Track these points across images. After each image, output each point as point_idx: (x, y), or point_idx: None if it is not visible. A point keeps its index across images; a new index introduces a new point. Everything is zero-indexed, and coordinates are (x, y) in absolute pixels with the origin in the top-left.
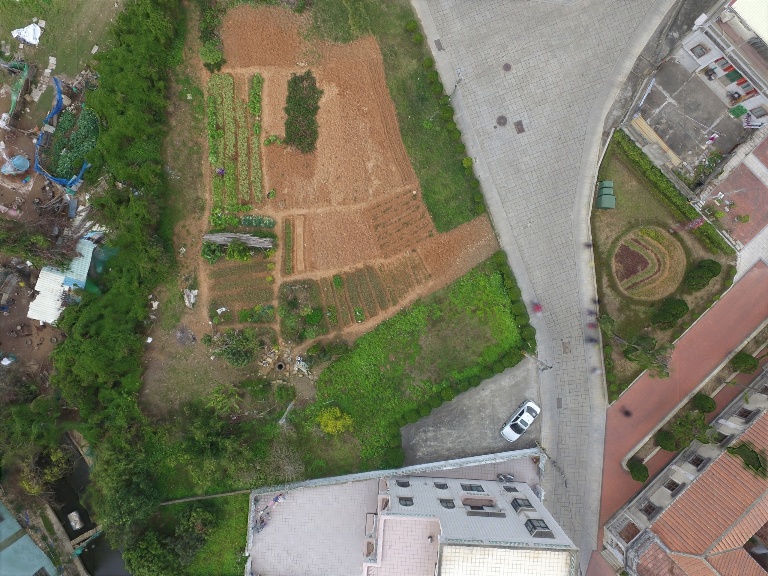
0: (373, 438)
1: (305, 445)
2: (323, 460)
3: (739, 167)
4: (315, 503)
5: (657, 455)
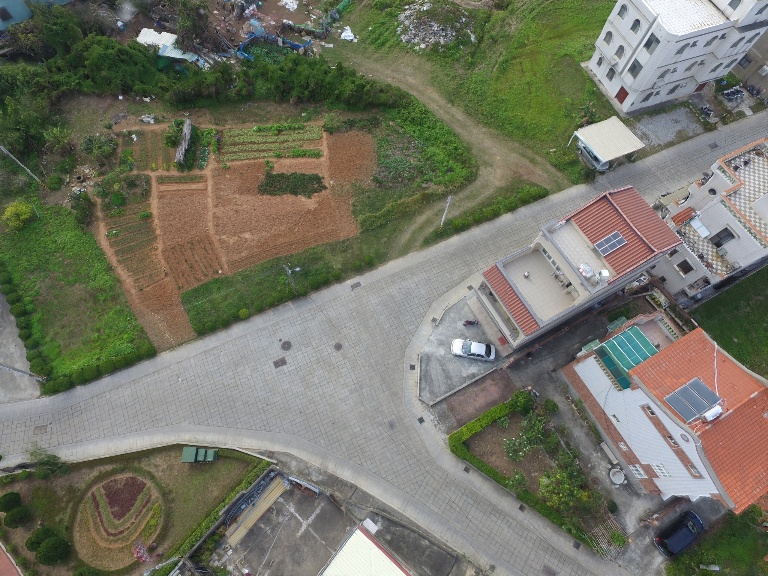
0: None
1: (5, 198)
2: None
3: None
4: None
5: None
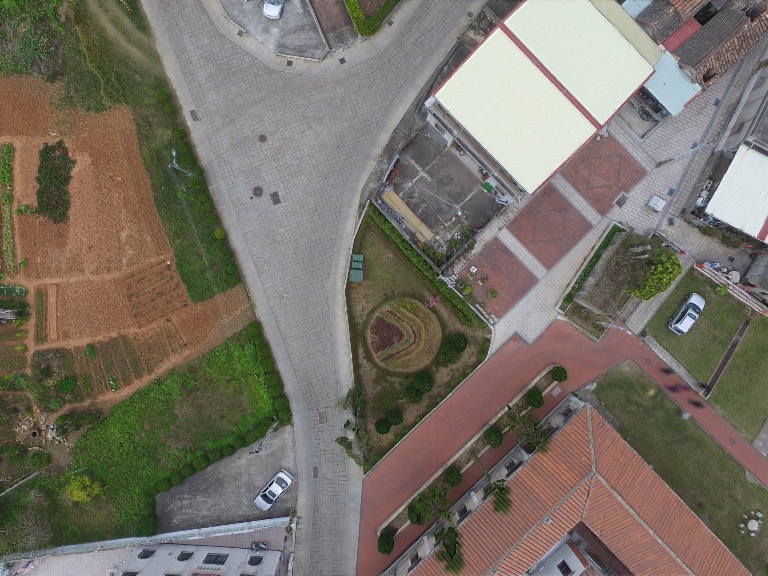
0: (127, 505)
1: (60, 511)
2: (77, 526)
3: (493, 241)
4: (69, 569)
5: (412, 525)
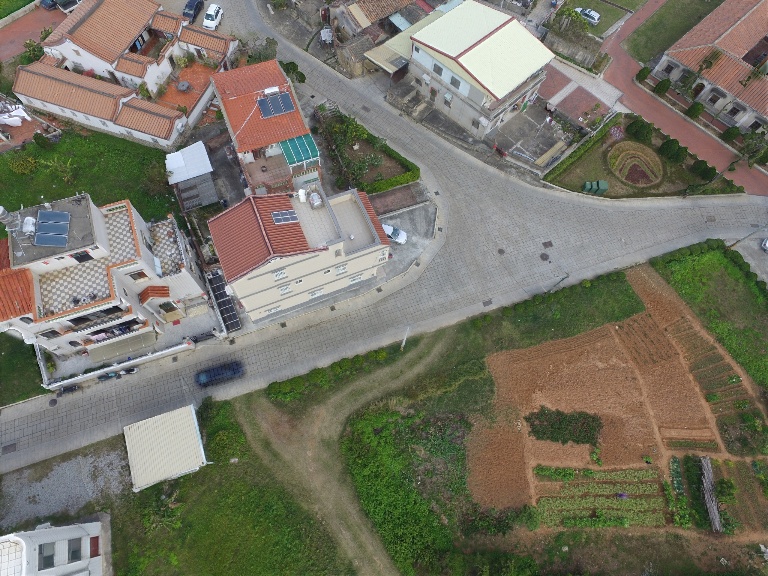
0: None
1: None
2: None
3: (559, 108)
4: None
5: None
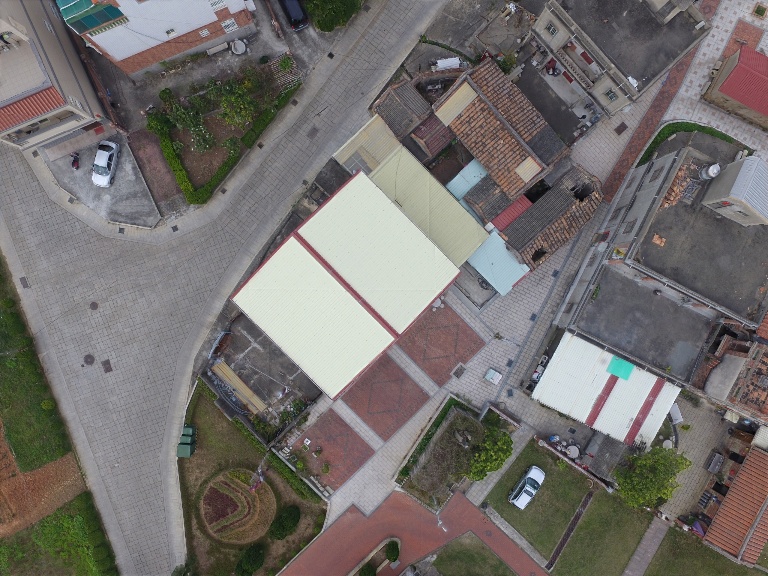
0: None
1: None
2: None
3: (327, 413)
4: None
5: None
